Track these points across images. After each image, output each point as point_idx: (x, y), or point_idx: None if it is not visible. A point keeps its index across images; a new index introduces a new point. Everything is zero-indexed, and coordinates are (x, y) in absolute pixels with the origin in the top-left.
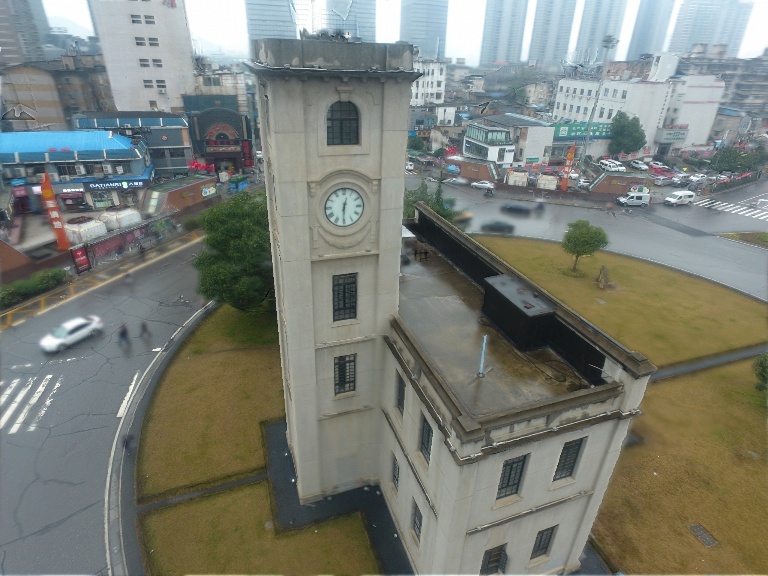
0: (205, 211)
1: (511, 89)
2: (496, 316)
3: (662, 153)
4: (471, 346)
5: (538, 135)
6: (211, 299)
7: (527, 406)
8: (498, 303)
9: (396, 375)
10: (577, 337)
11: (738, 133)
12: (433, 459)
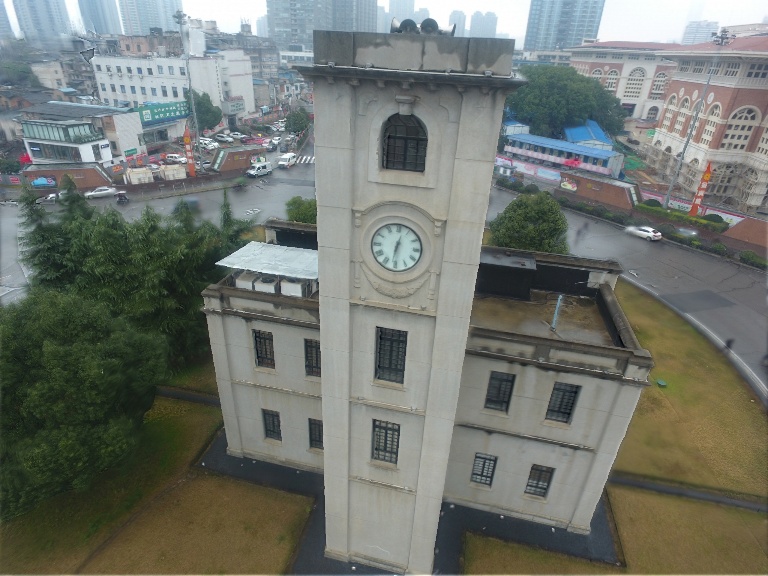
0: None
1: (12, 70)
2: (486, 286)
3: (232, 124)
4: (511, 317)
5: (125, 123)
6: (16, 514)
7: (626, 323)
8: (489, 274)
9: (489, 378)
10: (561, 269)
11: (271, 99)
12: (584, 410)
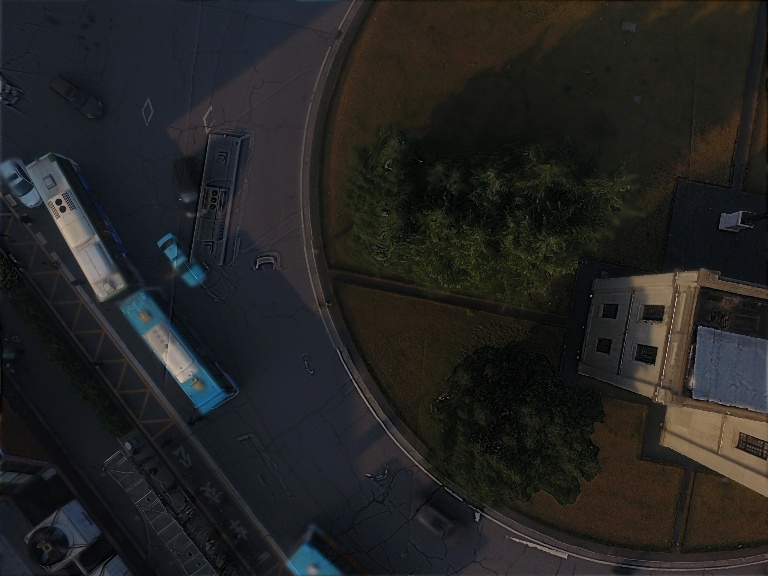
0: (79, 393)
1: None
2: None
3: None
4: None
5: None
6: None
7: None
8: None
9: None
10: None
11: None
12: None
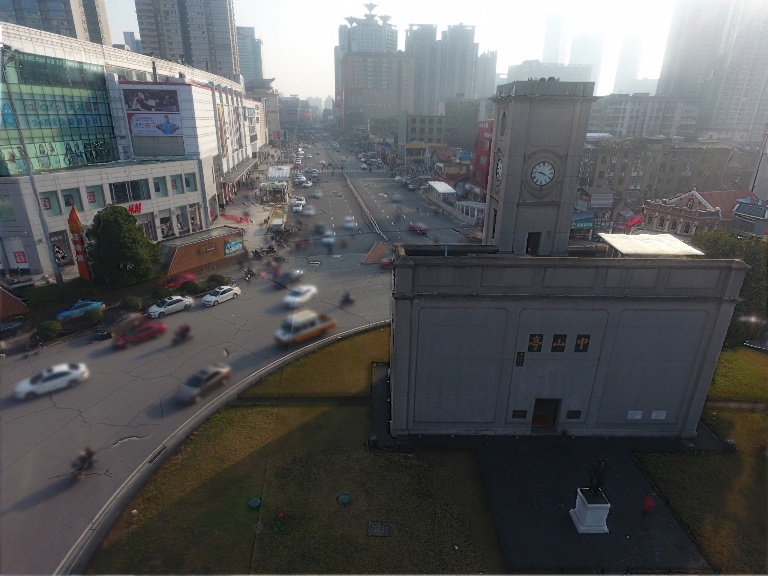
0: None
1: None
2: None
3: None
4: None
5: None
6: None
7: None
8: None
9: None
10: None
11: None
12: None
